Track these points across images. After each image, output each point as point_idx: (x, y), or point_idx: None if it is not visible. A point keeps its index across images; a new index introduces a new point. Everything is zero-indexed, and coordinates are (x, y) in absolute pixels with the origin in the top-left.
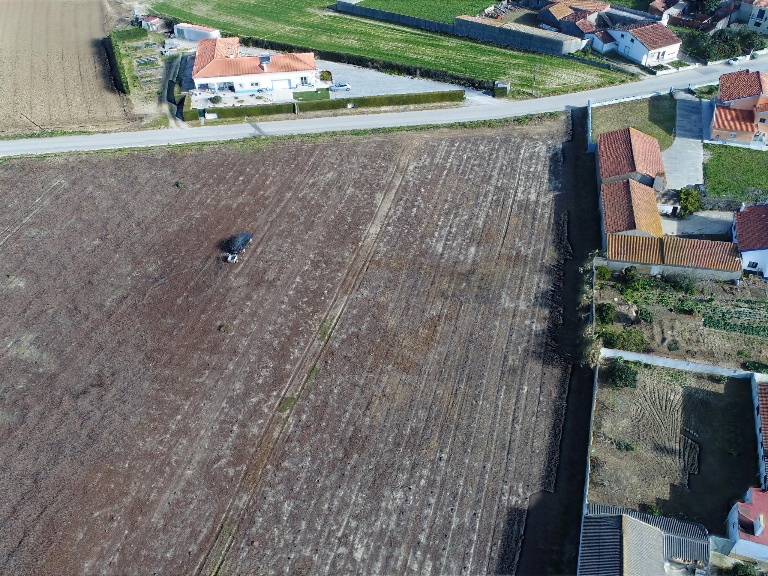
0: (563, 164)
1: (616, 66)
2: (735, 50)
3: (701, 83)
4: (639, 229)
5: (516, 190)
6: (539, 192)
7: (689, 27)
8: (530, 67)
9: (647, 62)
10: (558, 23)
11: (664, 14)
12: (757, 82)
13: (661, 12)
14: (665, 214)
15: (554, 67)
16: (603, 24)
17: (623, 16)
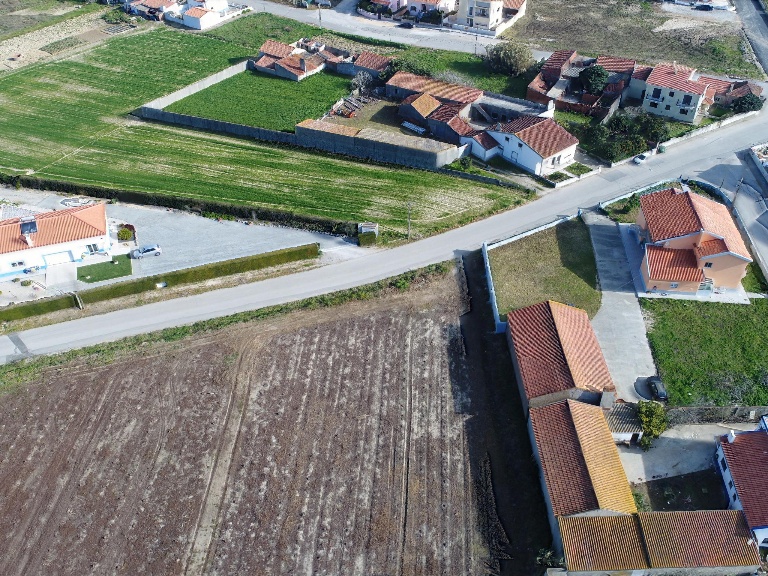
0: (467, 359)
1: (505, 179)
2: (640, 146)
3: (610, 196)
4: (603, 507)
5: (409, 420)
6: (442, 419)
7: (577, 112)
8: (399, 191)
9: (541, 171)
10: (425, 122)
11: (549, 103)
12: (690, 210)
13: (542, 95)
14: (622, 443)
15: (430, 188)
16: (478, 117)
17: (501, 108)
